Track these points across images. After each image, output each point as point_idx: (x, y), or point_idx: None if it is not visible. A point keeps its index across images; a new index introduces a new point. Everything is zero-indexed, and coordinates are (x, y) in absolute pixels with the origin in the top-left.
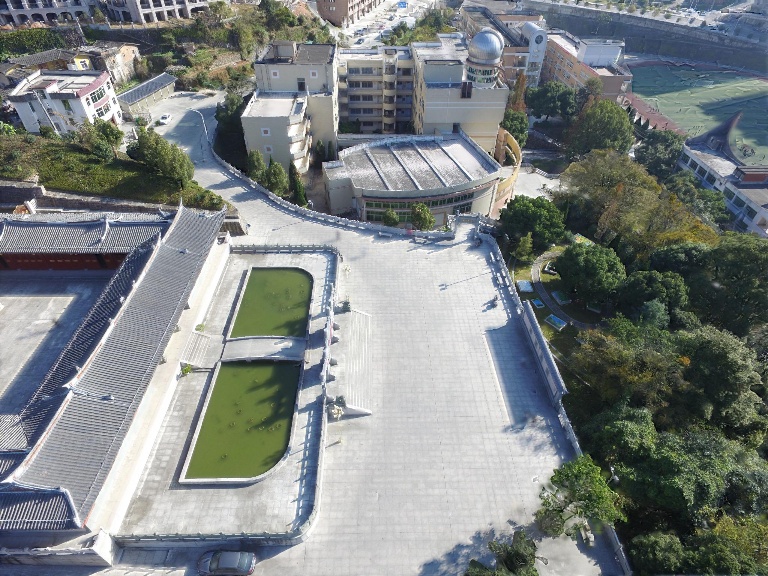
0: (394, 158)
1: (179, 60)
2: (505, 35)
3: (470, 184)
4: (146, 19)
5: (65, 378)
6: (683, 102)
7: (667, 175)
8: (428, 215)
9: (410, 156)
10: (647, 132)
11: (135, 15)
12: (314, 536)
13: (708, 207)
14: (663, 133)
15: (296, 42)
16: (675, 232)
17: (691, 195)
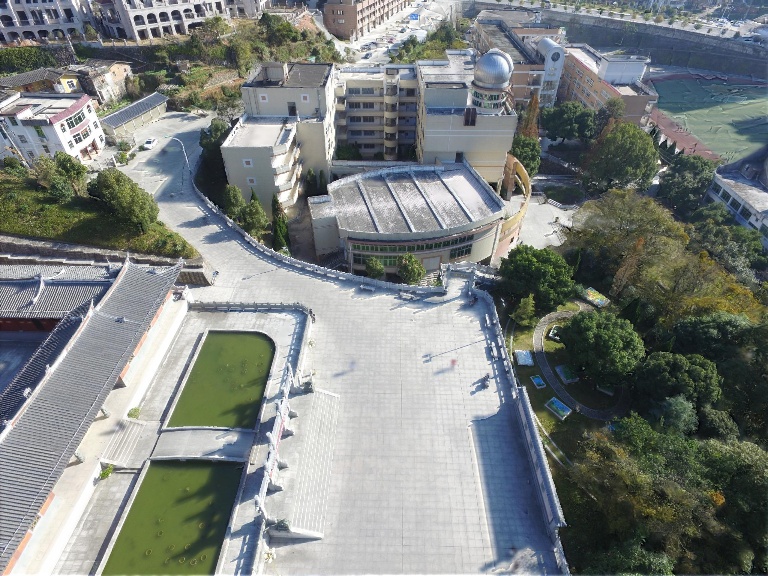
0: (388, 192)
1: (172, 79)
2: (520, 50)
3: (469, 225)
4: (140, 36)
5: None
6: (714, 120)
7: (695, 206)
8: (416, 267)
9: (406, 189)
10: (674, 157)
11: (129, 32)
12: None
13: (743, 251)
14: (692, 160)
15: (299, 58)
16: (705, 297)
17: (723, 236)
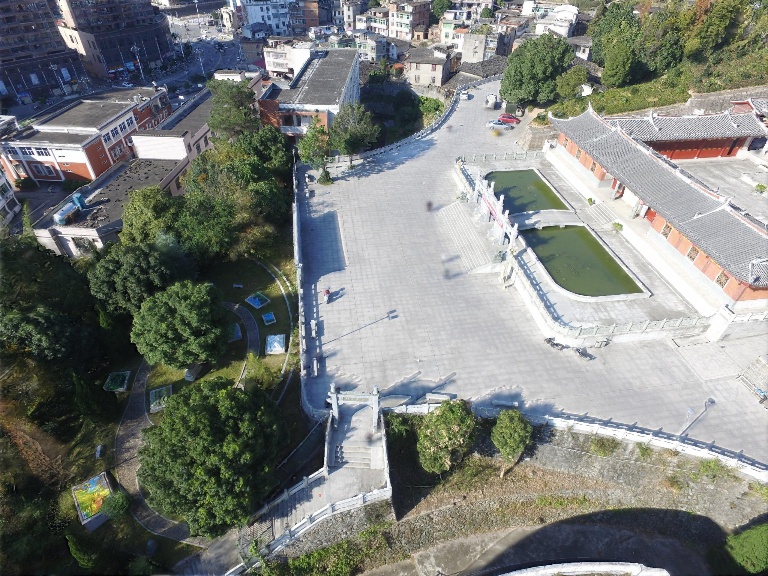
0: None
1: None
2: None
3: None
4: None
5: None
6: None
7: None
8: None
9: None
10: None
11: None
12: None
13: None
14: None
15: None
16: None
17: None
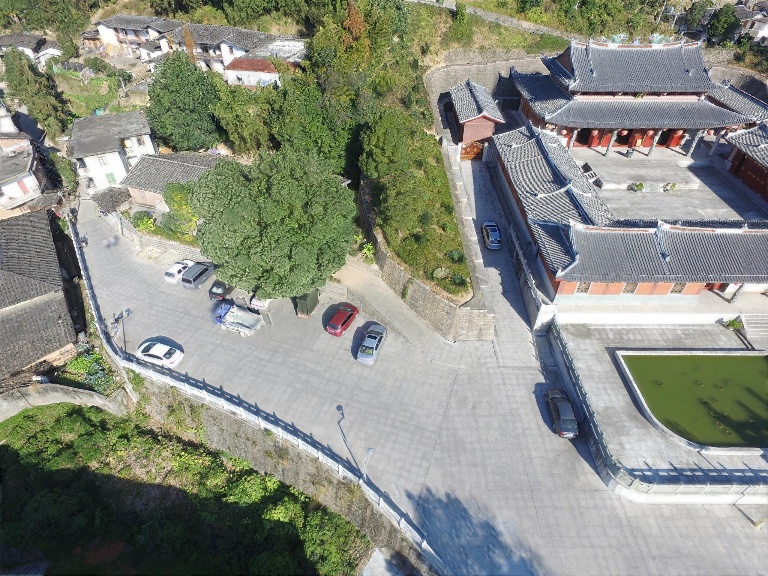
0: None
1: None
2: None
3: None
4: None
5: None
6: None
7: None
8: None
9: None
10: None
11: None
12: (618, 499)
13: None
14: None
15: None
16: None
17: None
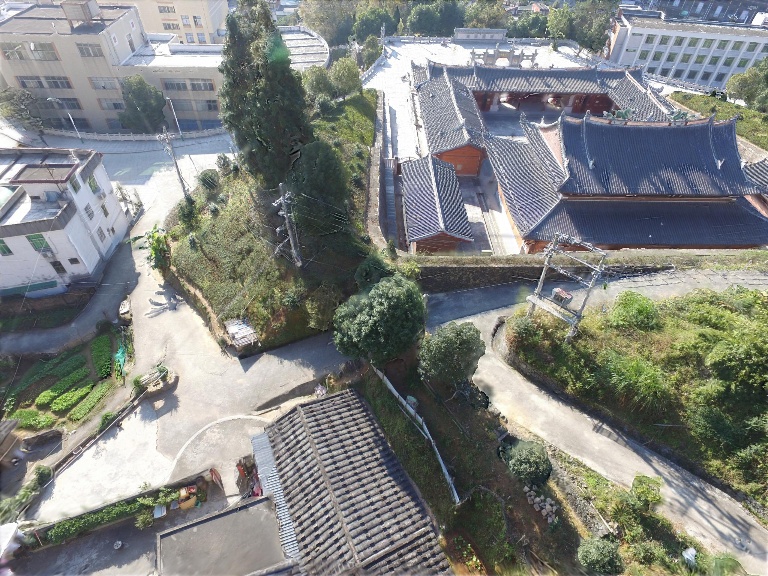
0: None
1: None
2: None
3: None
4: None
5: (586, 80)
6: None
7: None
8: None
9: None
10: None
11: None
12: None
13: None
14: None
15: None
16: None
17: None
